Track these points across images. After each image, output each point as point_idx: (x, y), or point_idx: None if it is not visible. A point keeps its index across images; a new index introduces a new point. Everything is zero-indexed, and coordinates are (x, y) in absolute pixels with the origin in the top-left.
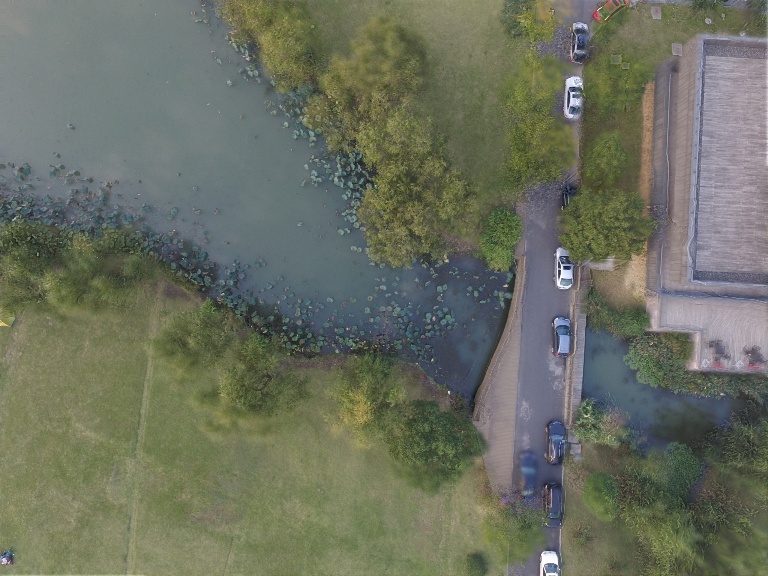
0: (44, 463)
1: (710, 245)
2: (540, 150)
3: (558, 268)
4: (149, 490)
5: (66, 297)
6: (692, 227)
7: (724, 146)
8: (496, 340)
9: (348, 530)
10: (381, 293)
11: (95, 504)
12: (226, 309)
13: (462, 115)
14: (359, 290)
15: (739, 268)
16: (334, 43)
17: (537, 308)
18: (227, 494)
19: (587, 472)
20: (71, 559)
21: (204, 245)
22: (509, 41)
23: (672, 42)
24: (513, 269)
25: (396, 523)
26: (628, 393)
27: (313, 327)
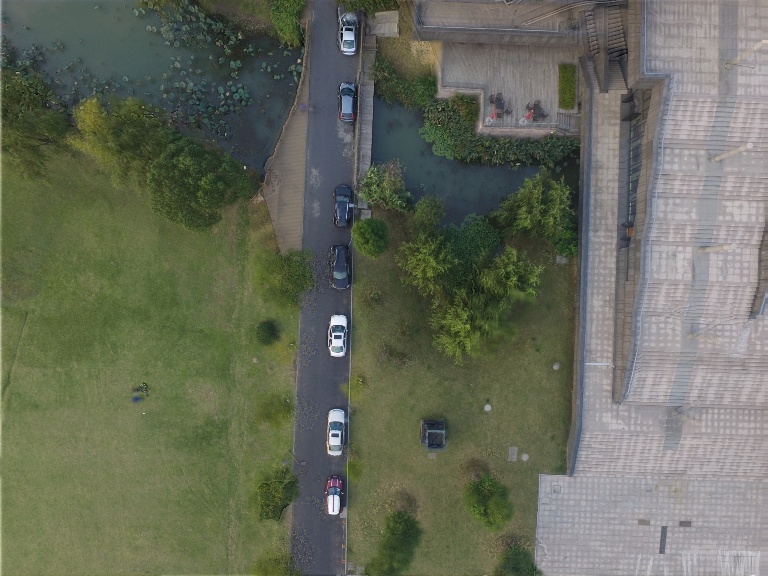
0: None
1: None
2: None
3: (340, 31)
4: None
5: None
6: None
7: None
8: (288, 113)
9: (141, 302)
10: (176, 71)
11: None
12: (21, 87)
13: None
14: (154, 69)
15: None
16: None
17: (325, 76)
18: (23, 270)
19: (377, 237)
20: None
21: (2, 28)
22: None
23: None
24: (301, 39)
25: (189, 295)
26: (424, 166)
27: (109, 106)
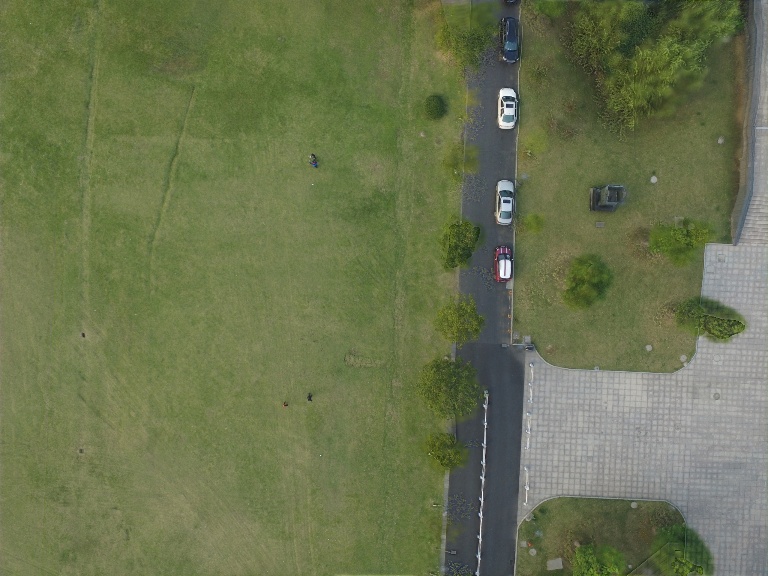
0: (7, 14)
1: None
2: None
3: None
4: (111, 41)
5: None
6: None
7: None
8: None
9: (308, 76)
10: None
11: (57, 52)
12: None
13: None
14: None
15: None
16: None
17: None
18: (189, 46)
19: (544, 15)
20: (33, 104)
21: None
22: None
23: None
24: None
25: (356, 71)
26: None
27: None
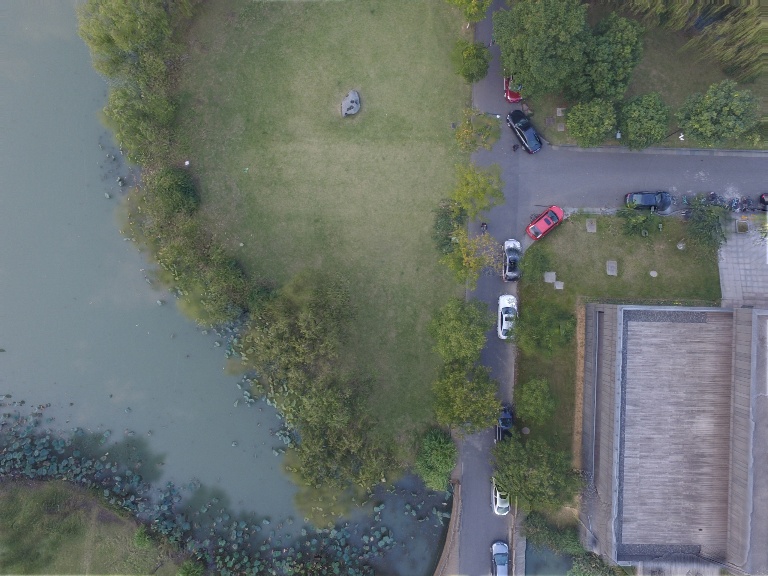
0: None
1: (636, 517)
2: (474, 370)
3: (494, 495)
4: None
5: (1, 523)
6: (615, 506)
7: (649, 415)
8: (435, 561)
9: None
10: (318, 513)
11: None
12: (160, 536)
13: (395, 333)
14: (295, 511)
15: (667, 540)
16: (264, 261)
17: (475, 531)
18: None
19: None
20: None
21: (138, 469)
22: (441, 257)
23: (607, 259)
24: (450, 491)
25: None
26: None
27: (250, 549)
